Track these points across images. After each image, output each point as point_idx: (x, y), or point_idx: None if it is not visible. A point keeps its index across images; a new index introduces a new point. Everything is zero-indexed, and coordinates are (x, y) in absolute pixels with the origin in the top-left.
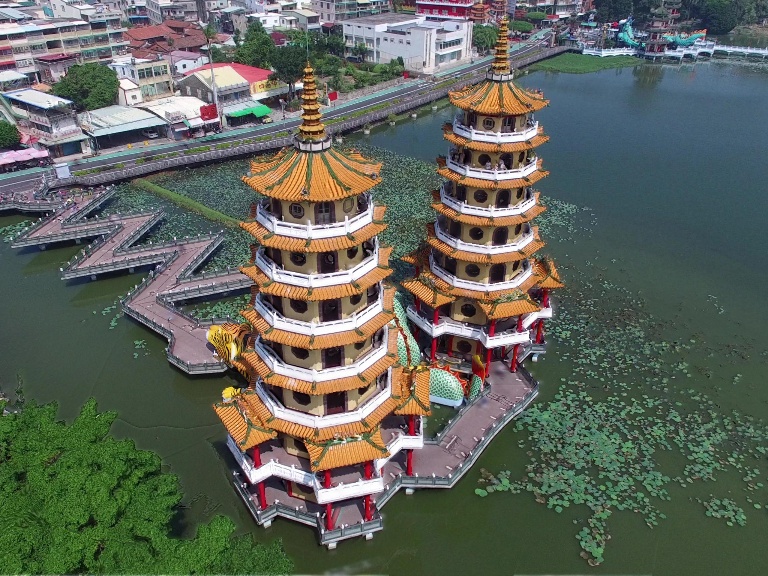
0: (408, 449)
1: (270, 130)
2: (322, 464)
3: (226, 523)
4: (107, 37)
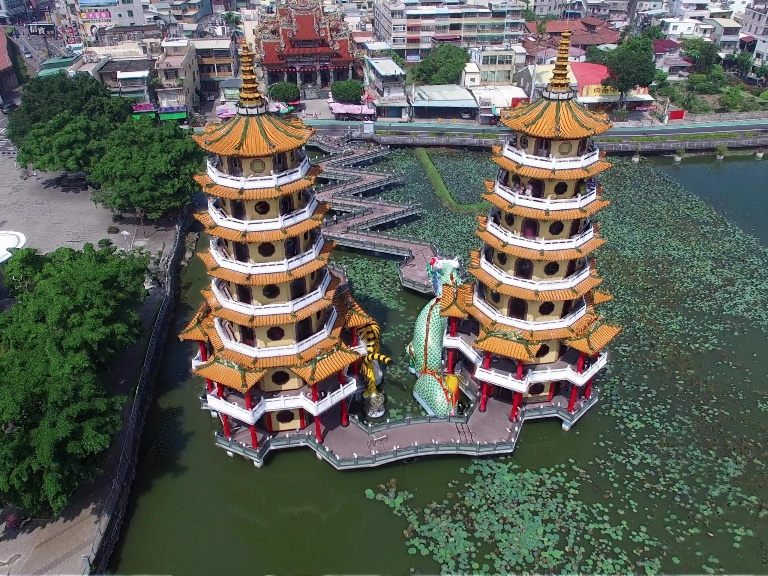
0: (307, 411)
1: None
2: (203, 371)
3: (81, 358)
4: (504, 26)
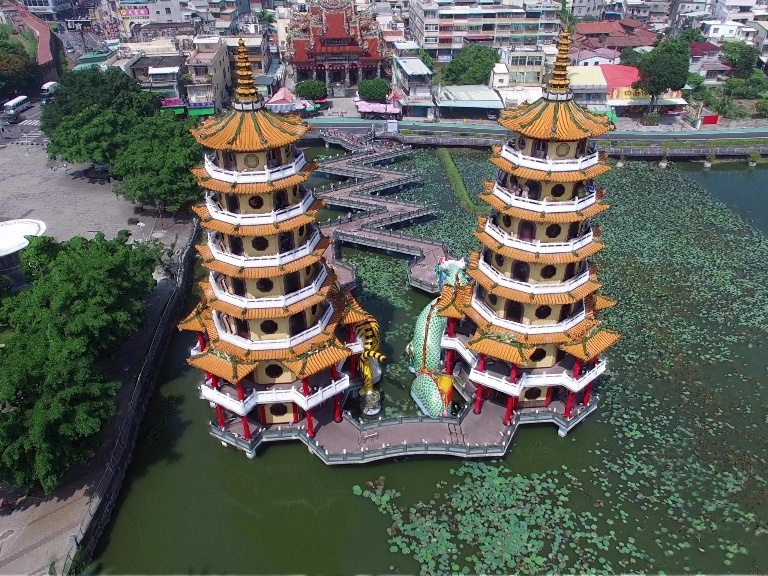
0: None
1: (600, 137)
2: (196, 361)
3: (79, 343)
4: (538, 26)
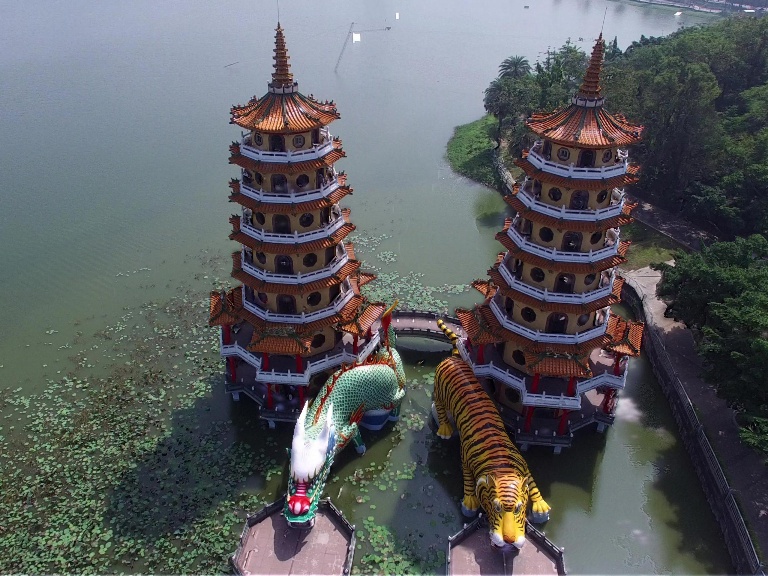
0: None
1: None
2: None
3: None
4: None
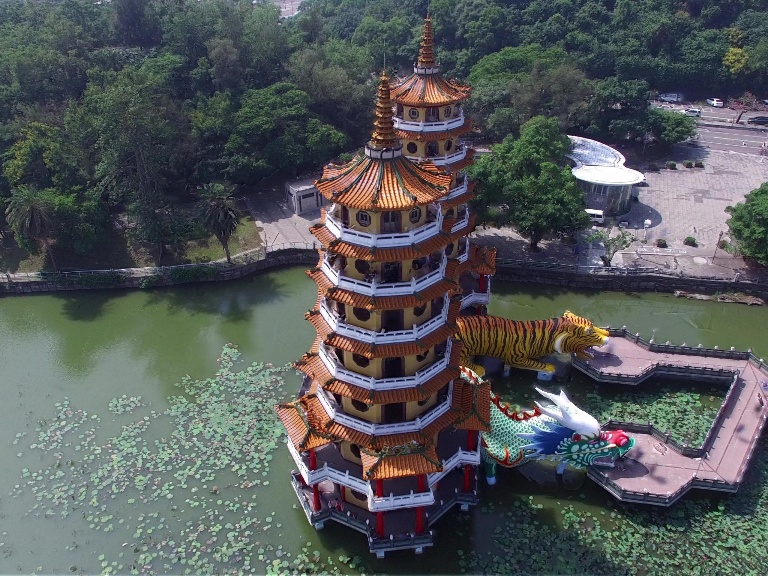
0: None
1: None
2: None
3: None
4: None
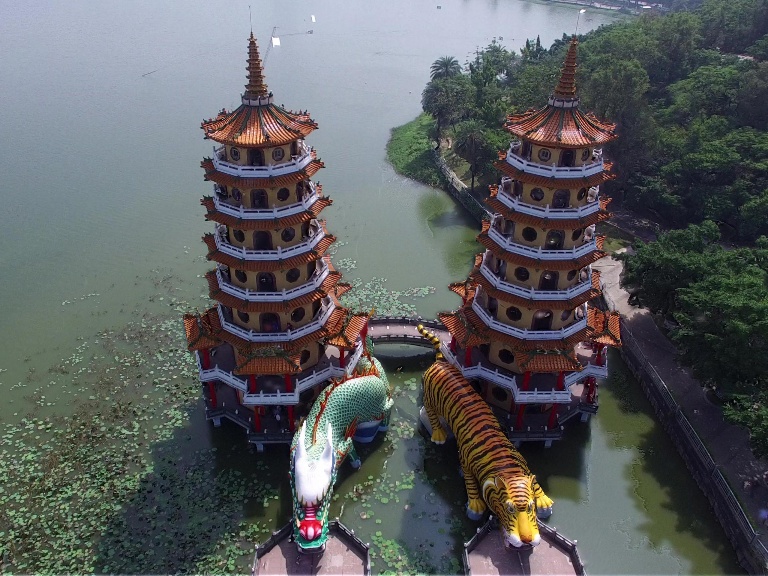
0: None
1: None
2: None
3: None
4: None
